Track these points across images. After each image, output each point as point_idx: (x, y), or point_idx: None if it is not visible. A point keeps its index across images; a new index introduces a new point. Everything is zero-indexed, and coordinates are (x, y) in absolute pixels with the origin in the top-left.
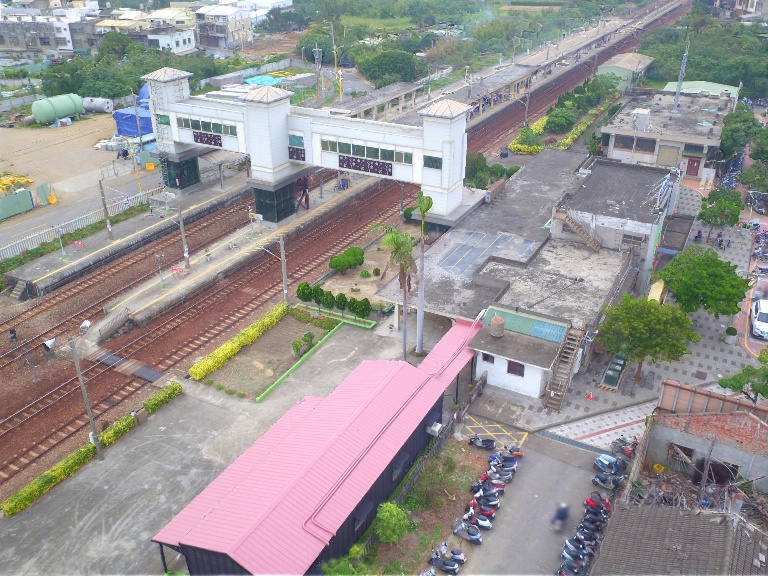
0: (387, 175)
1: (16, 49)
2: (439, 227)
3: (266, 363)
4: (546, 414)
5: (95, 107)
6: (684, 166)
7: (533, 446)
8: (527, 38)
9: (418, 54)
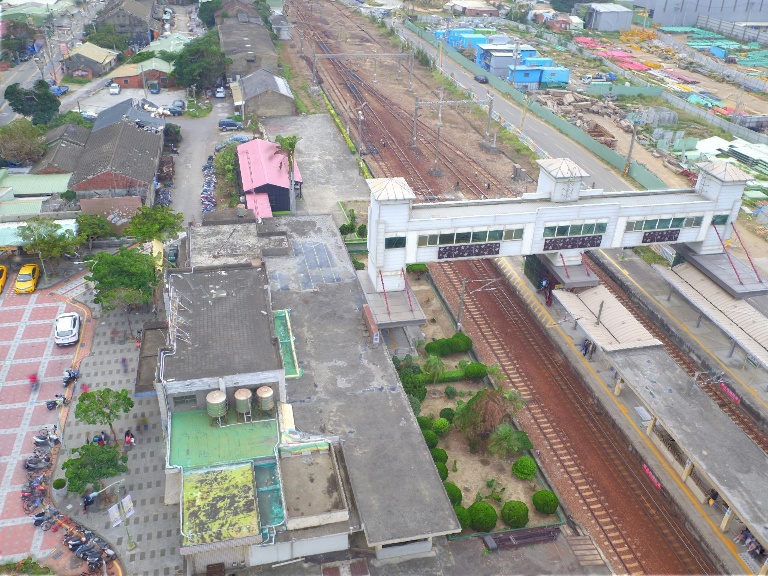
0: None
1: None
2: None
3: None
4: None
5: None
6: None
7: None
8: None
9: None
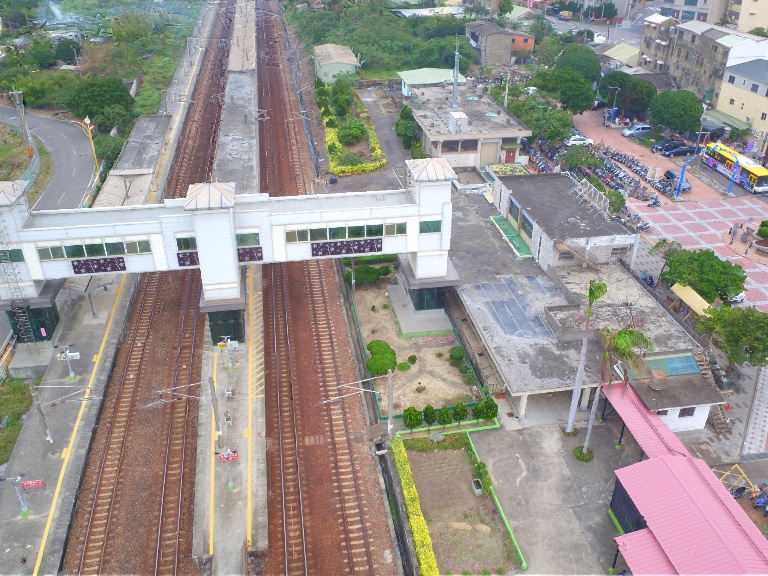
0: (376, 252)
1: None
2: (437, 289)
3: (465, 519)
4: (726, 440)
5: None
6: (503, 158)
7: (755, 474)
8: (165, 31)
9: (65, 67)
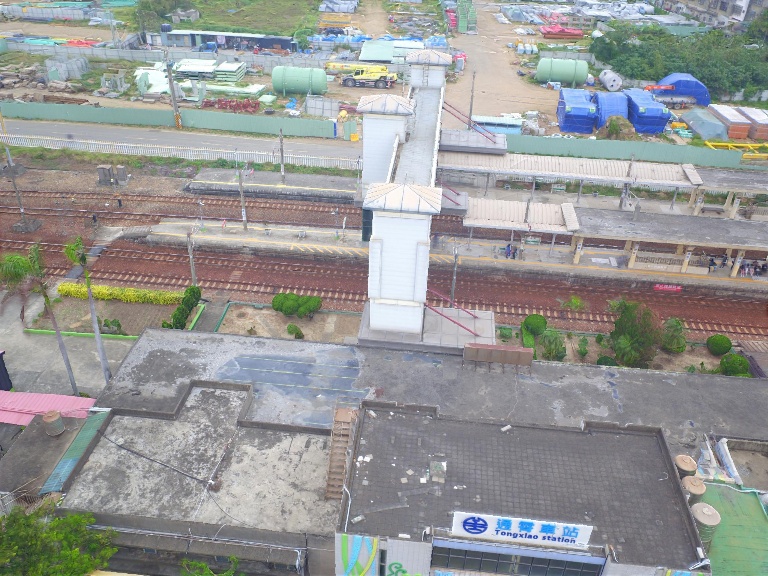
0: None
1: (700, 8)
2: None
3: None
4: None
5: (604, 81)
6: None
7: None
8: None
9: None
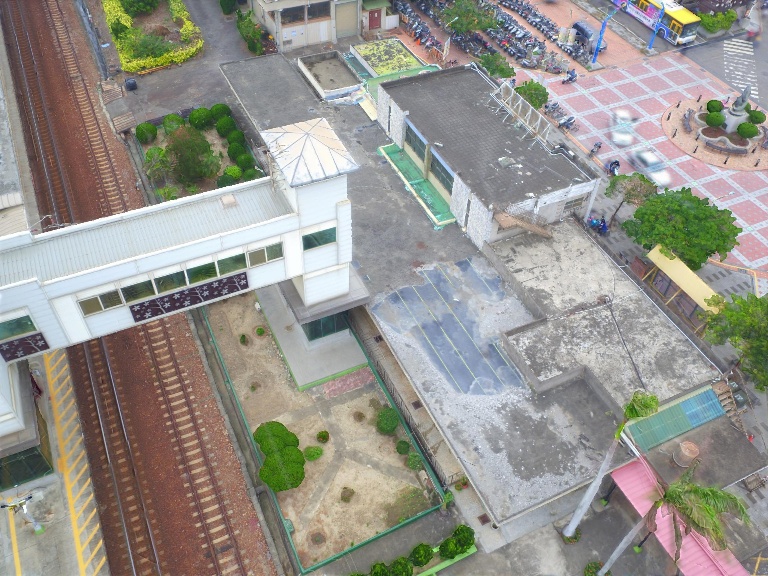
0: (239, 291)
1: None
2: None
3: None
4: (761, 499)
5: None
6: (366, 21)
7: None
8: None
9: None
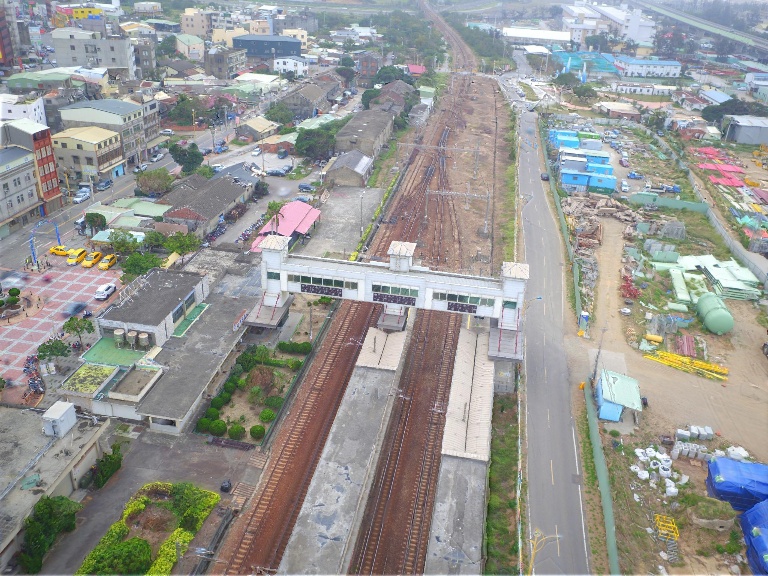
0: None
1: None
2: None
3: None
4: None
5: None
6: None
7: None
8: None
9: None
